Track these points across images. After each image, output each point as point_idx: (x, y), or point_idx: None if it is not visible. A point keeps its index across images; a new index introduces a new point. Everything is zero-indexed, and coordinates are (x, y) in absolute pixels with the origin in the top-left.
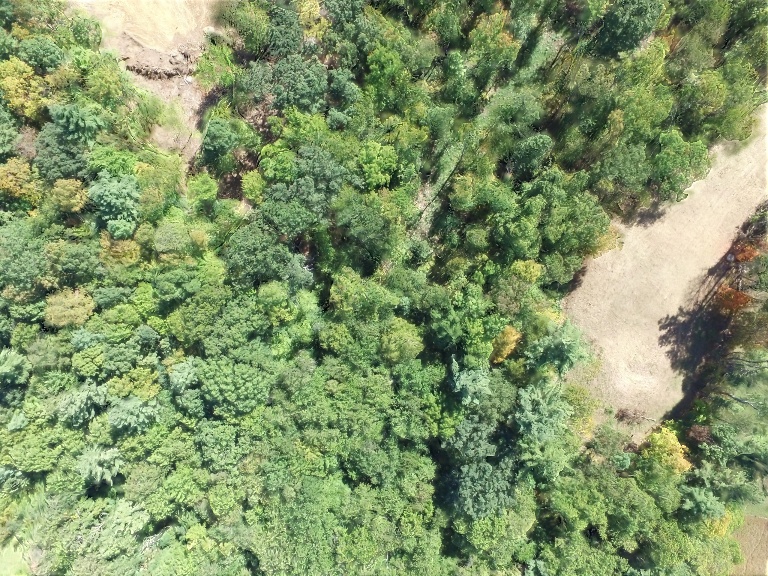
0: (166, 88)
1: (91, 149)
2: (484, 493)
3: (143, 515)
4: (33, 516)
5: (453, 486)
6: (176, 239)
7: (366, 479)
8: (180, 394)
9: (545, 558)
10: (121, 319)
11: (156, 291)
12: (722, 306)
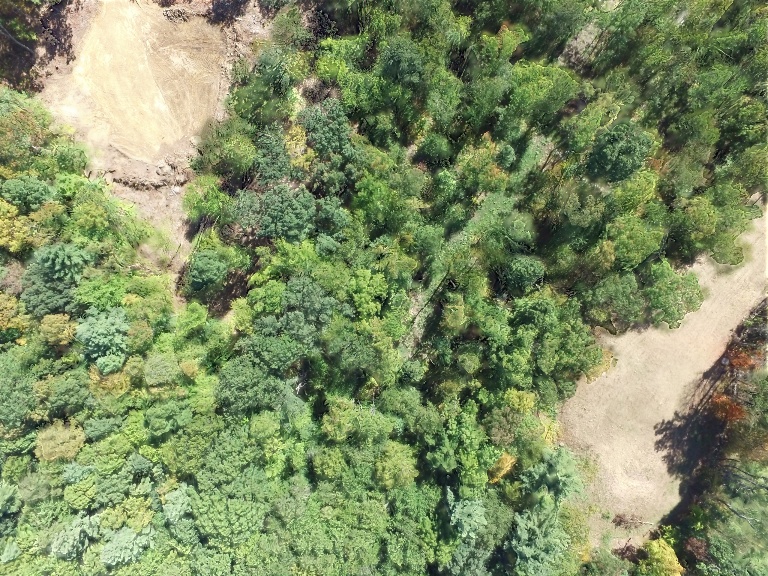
0: (154, 199)
1: (78, 284)
2: None
3: None
4: None
5: None
6: (166, 372)
7: None
8: (174, 525)
9: None
10: (113, 449)
11: (147, 419)
12: (718, 410)
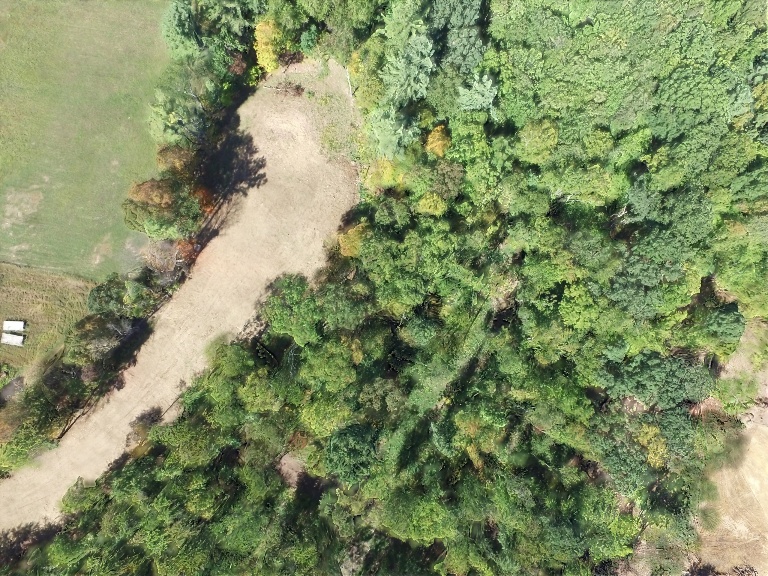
0: (753, 390)
1: None
2: None
3: None
4: None
5: None
6: (761, 226)
7: (557, 14)
8: (740, 84)
9: None
10: None
11: None
12: None
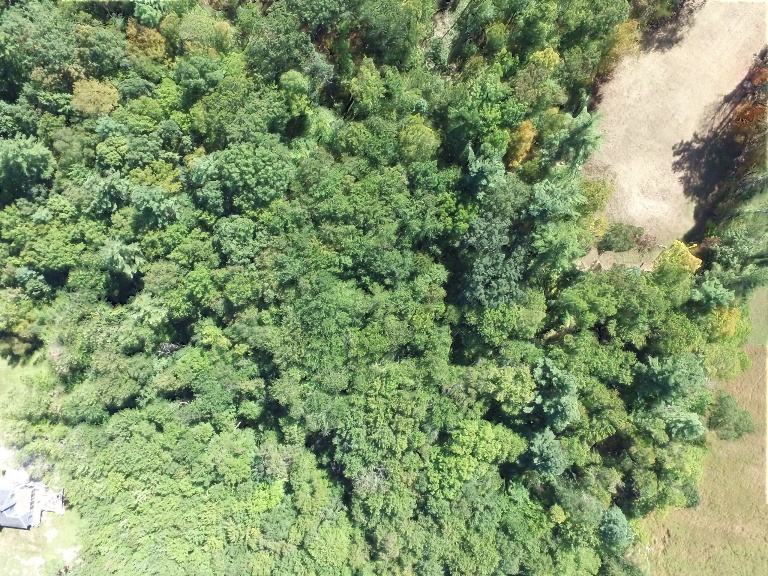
0: None
1: None
2: (496, 279)
3: (161, 311)
4: (54, 315)
5: (465, 286)
6: (201, 27)
7: (380, 279)
8: (201, 185)
9: (554, 357)
10: (145, 112)
11: (179, 87)
12: (737, 133)
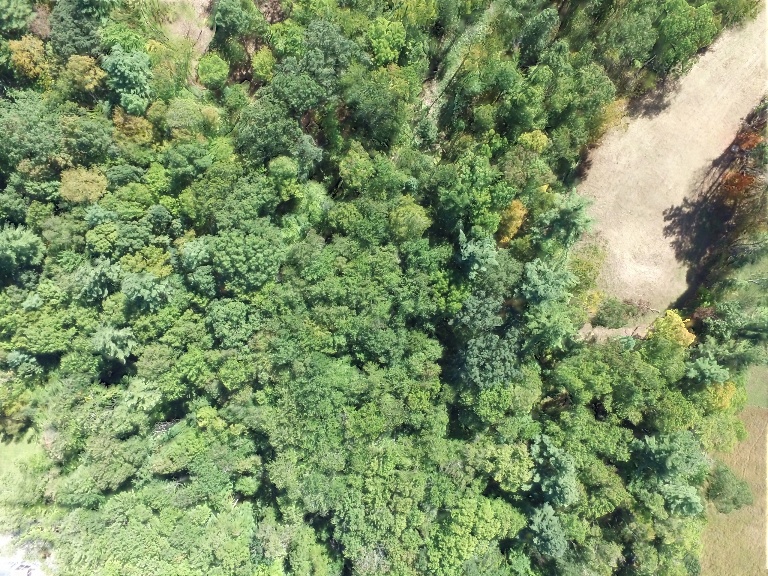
0: None
1: (105, 25)
2: (491, 361)
3: (155, 394)
4: (47, 399)
5: (460, 363)
6: (188, 115)
7: (374, 358)
8: (192, 270)
9: (551, 433)
10: (134, 198)
11: (168, 171)
12: (726, 197)
